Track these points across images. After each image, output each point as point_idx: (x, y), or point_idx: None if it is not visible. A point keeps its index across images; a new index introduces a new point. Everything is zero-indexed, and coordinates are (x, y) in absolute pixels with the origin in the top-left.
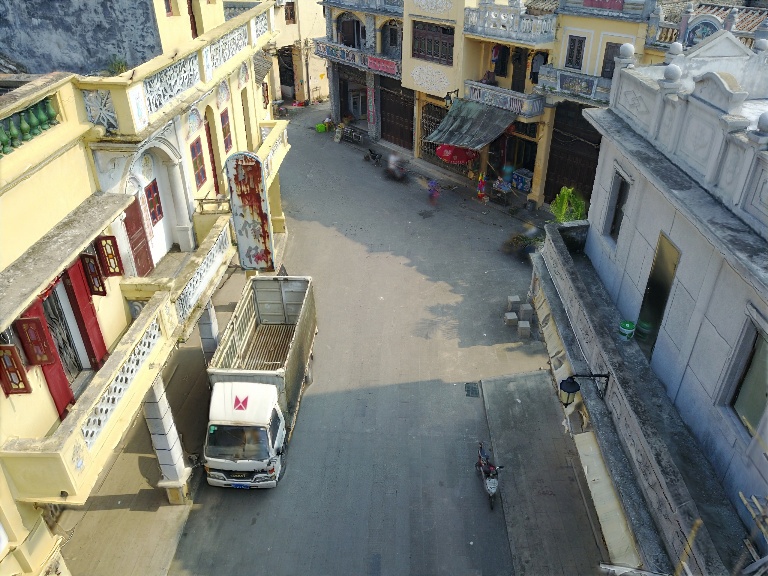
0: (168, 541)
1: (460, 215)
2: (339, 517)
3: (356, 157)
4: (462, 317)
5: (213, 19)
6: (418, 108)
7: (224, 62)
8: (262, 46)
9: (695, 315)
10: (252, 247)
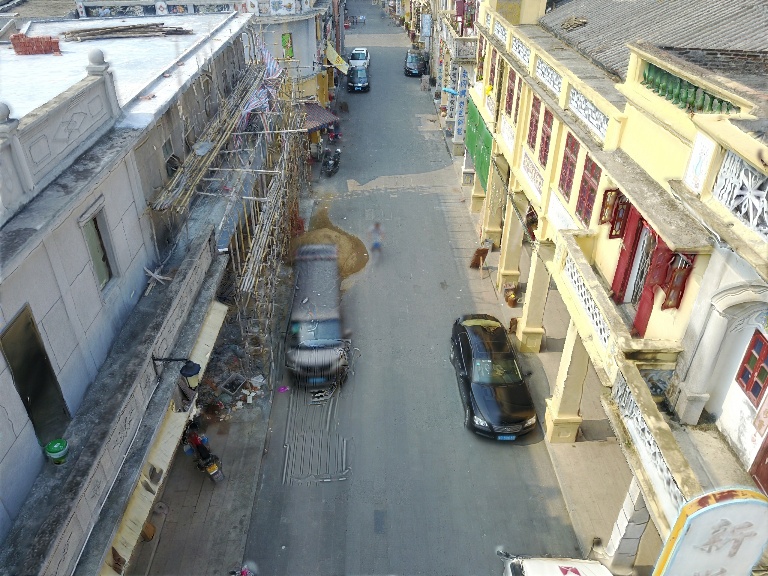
0: (587, 534)
1: None
2: (422, 569)
3: None
4: None
5: None
6: None
7: None
8: None
9: (68, 300)
10: None
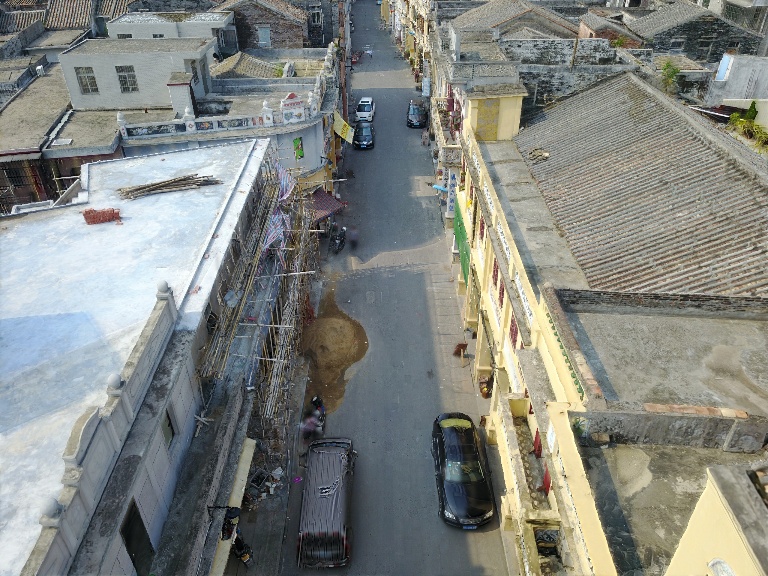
0: None
1: None
2: None
3: None
4: None
5: None
6: None
7: None
8: None
9: None
10: None
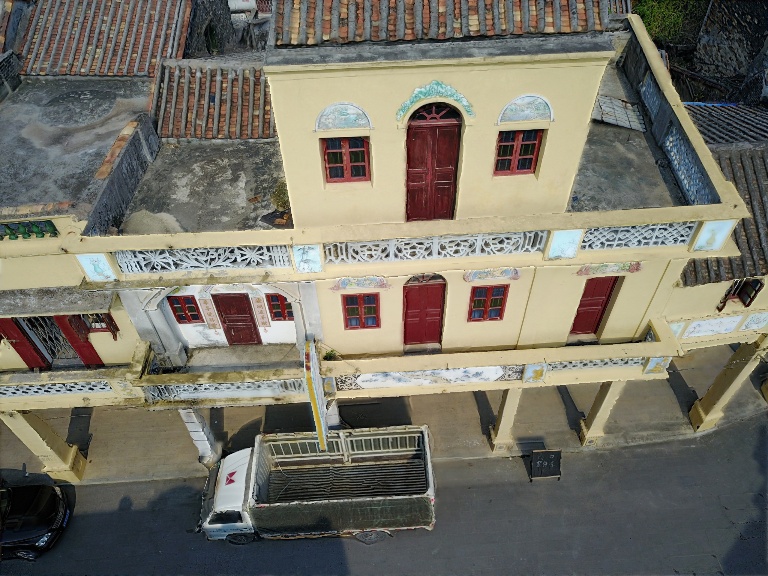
0: (176, 470)
1: None
2: None
3: None
4: None
5: (510, 196)
6: None
7: (401, 259)
8: (592, 263)
9: None
10: None
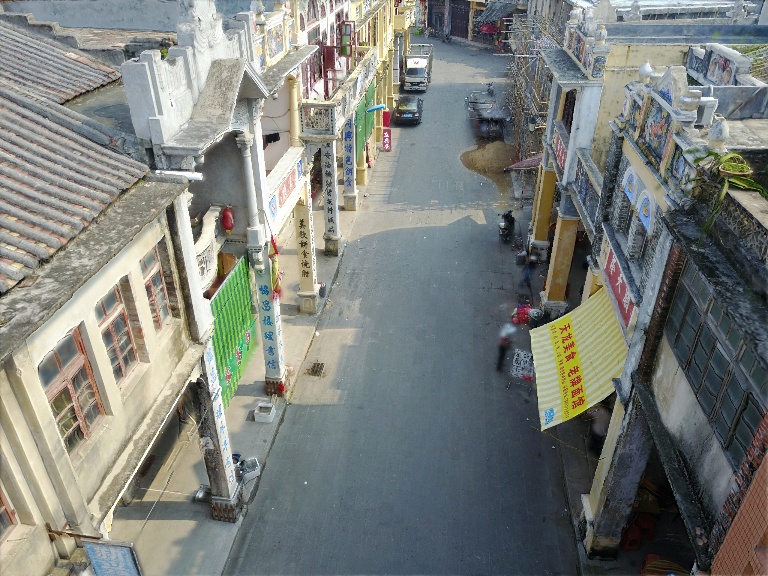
0: None
1: (489, 56)
2: None
3: (438, 42)
4: (487, 74)
5: None
6: (472, 13)
7: None
8: None
9: None
10: (420, 19)
